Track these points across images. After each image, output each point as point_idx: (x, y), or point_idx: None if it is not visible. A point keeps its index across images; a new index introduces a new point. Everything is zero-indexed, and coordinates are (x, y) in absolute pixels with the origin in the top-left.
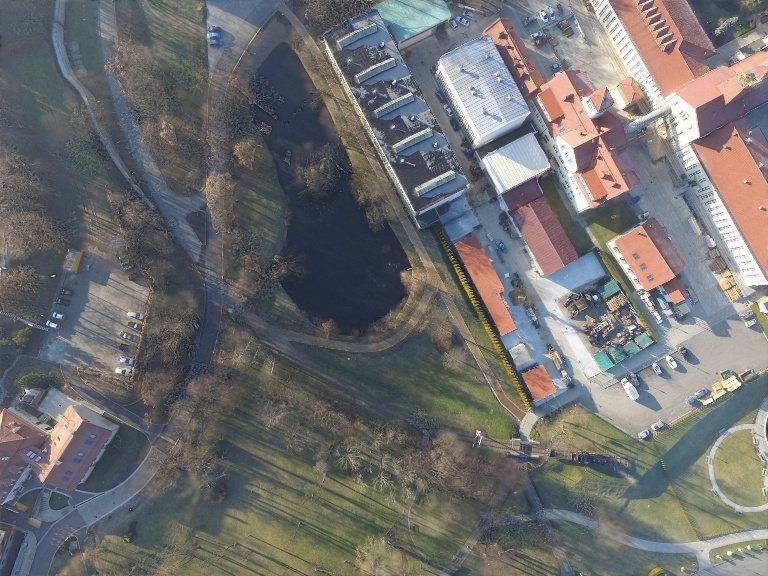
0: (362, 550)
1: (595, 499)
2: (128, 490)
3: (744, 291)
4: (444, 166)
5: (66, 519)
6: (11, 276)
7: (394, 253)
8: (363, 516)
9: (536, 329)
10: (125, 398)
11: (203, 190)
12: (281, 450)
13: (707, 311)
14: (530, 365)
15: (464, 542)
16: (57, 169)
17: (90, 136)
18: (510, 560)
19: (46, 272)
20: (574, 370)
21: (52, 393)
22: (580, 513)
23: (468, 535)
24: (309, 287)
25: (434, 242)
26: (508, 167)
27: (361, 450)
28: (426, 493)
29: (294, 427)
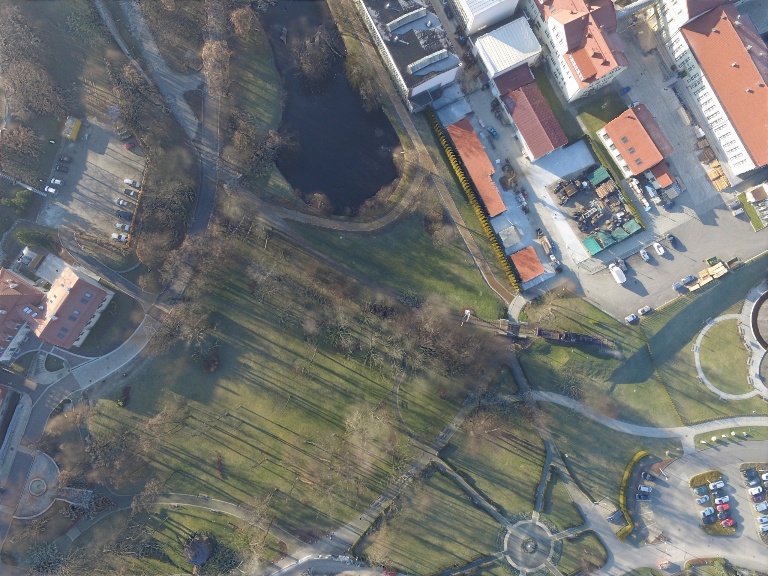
0: (351, 424)
1: (581, 382)
2: (122, 356)
3: (732, 180)
4: (437, 45)
5: (61, 382)
6: (11, 136)
7: (387, 137)
8: (352, 392)
9: (526, 214)
10: (121, 264)
11: (200, 69)
12: (273, 324)
13: (695, 200)
14: (519, 249)
15: (451, 419)
16: (58, 39)
17: (91, 11)
18: (497, 439)
19: (45, 137)
20: (563, 255)
21: (49, 258)
22: (567, 396)
23: (456, 413)
24: (303, 165)
25: (426, 126)
26: (500, 49)
27: (352, 327)
28: (415, 371)
29: (286, 303)
